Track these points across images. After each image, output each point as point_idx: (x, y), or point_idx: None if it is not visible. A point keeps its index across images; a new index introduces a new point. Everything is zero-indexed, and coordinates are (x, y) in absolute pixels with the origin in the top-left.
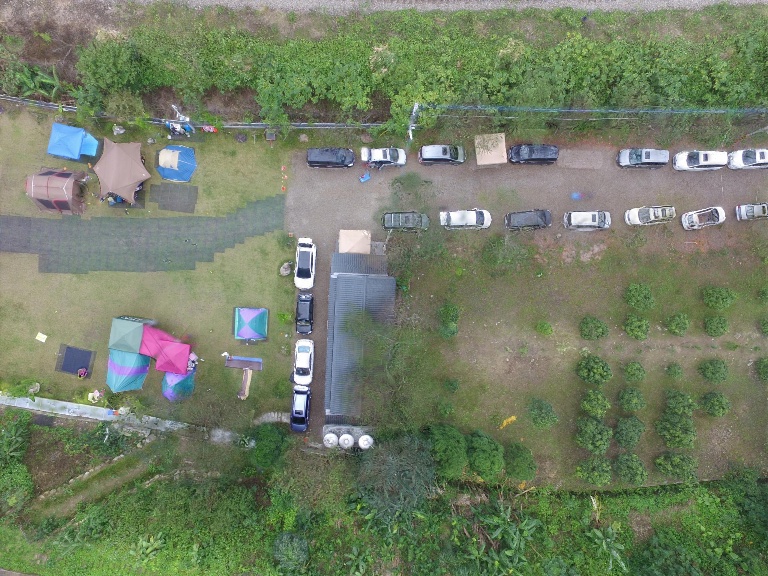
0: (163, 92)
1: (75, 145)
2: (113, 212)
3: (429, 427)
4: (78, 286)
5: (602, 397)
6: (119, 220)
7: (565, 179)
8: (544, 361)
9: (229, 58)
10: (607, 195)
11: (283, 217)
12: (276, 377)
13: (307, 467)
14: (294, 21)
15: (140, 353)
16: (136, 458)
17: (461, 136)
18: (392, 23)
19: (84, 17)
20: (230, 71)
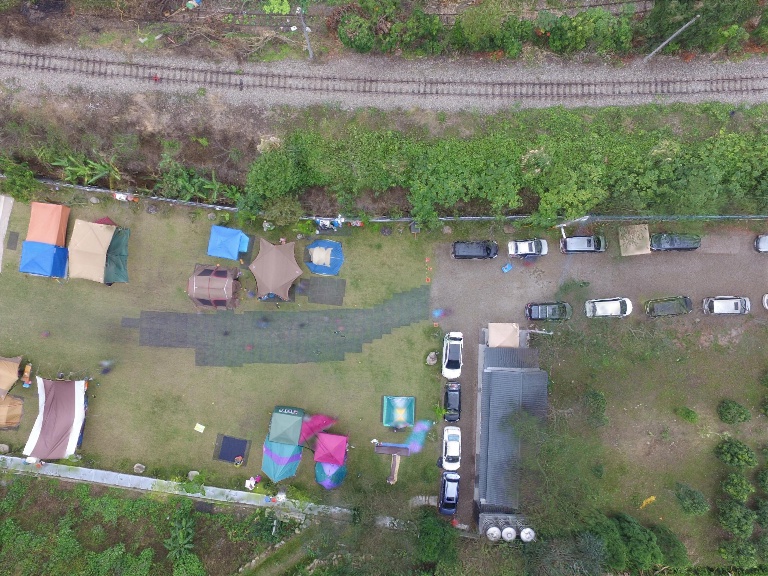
0: (314, 190)
1: (234, 247)
2: (265, 306)
3: (577, 512)
4: (233, 378)
5: (745, 481)
6: (271, 314)
7: (703, 264)
8: (683, 443)
9: (383, 160)
10: (744, 279)
11: (428, 307)
12: (423, 462)
13: (455, 548)
14: (444, 121)
15: (299, 445)
16: (296, 544)
17: (600, 224)
18: (541, 120)
19: (240, 121)
20: (385, 173)
